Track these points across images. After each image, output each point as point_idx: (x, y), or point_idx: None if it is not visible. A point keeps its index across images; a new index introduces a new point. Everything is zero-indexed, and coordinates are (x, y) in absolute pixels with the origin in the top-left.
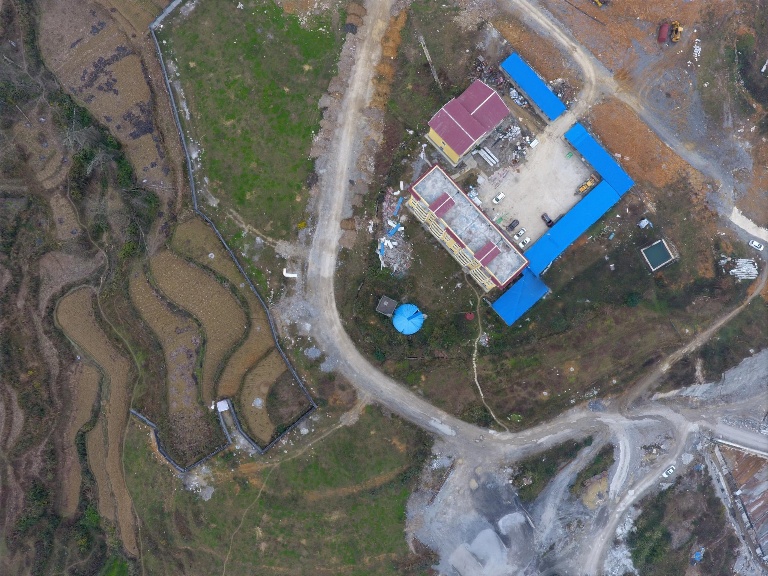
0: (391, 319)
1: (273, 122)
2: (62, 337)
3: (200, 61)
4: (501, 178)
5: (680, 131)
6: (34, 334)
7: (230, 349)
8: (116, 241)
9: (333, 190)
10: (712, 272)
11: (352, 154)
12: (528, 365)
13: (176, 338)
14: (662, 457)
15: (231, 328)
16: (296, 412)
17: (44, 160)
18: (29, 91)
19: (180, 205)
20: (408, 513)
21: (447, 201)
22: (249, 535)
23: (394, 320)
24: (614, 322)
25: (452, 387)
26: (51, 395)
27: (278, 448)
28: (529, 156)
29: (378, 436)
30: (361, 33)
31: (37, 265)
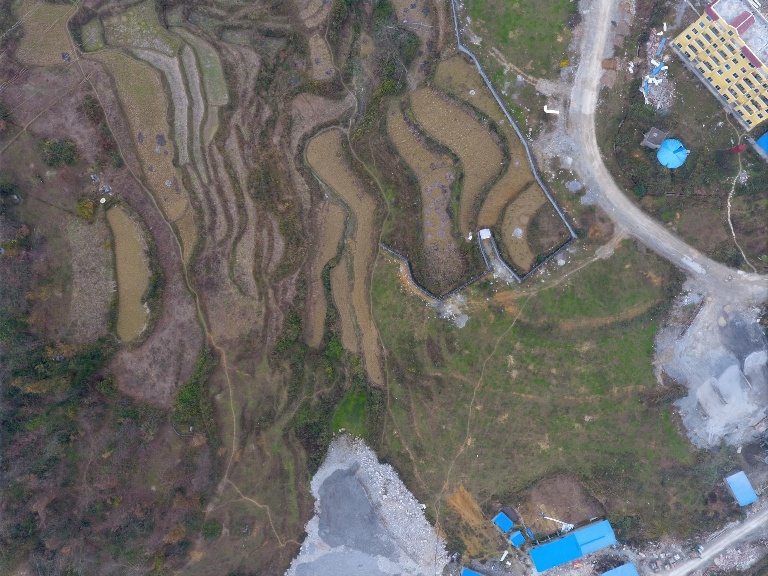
0: (657, 152)
1: None
2: (312, 175)
3: None
4: None
5: None
6: (288, 169)
7: (491, 181)
8: (367, 84)
9: (595, 30)
10: None
11: None
12: None
13: (431, 174)
14: None
15: (488, 164)
16: (556, 242)
17: None
18: None
19: (442, 44)
20: (657, 347)
21: (749, 18)
22: (501, 362)
23: (658, 154)
24: None
25: (705, 226)
26: (303, 228)
27: (536, 277)
28: None
29: (633, 270)
30: None
31: (290, 105)
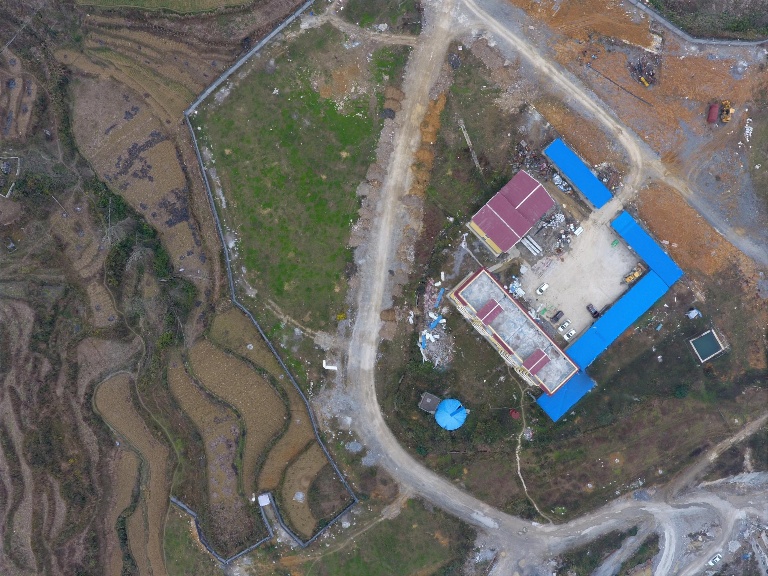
0: (434, 415)
1: (311, 211)
2: (101, 423)
3: (236, 148)
4: (545, 267)
5: (730, 216)
6: (74, 421)
7: (270, 442)
8: (153, 327)
9: (372, 280)
10: (764, 363)
11: (392, 244)
12: (572, 458)
13: (215, 428)
14: (708, 544)
15: (270, 419)
16: (338, 506)
17: (81, 249)
18: (65, 181)
19: (218, 295)
20: None
21: (495, 308)
22: None
23: (436, 415)
24: (661, 413)
25: (495, 480)
26: (92, 482)
27: (320, 542)
28: (573, 244)
29: (420, 530)
30: (399, 118)
31: (75, 351)
